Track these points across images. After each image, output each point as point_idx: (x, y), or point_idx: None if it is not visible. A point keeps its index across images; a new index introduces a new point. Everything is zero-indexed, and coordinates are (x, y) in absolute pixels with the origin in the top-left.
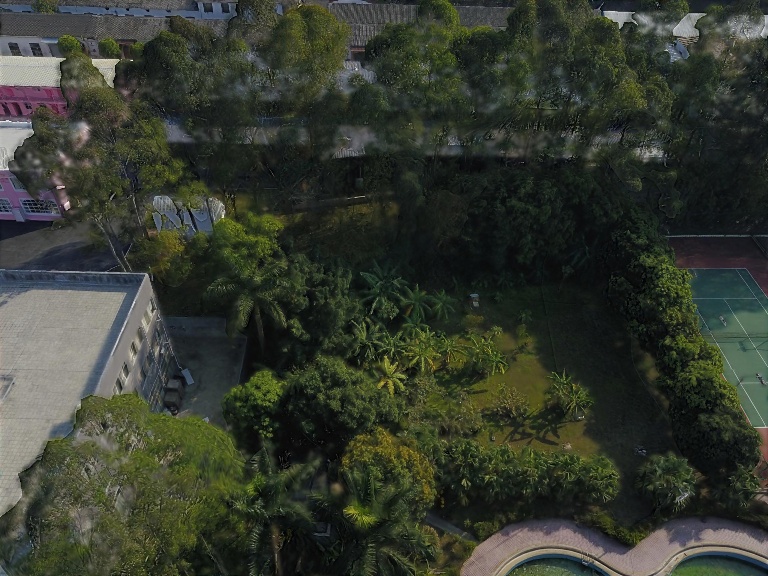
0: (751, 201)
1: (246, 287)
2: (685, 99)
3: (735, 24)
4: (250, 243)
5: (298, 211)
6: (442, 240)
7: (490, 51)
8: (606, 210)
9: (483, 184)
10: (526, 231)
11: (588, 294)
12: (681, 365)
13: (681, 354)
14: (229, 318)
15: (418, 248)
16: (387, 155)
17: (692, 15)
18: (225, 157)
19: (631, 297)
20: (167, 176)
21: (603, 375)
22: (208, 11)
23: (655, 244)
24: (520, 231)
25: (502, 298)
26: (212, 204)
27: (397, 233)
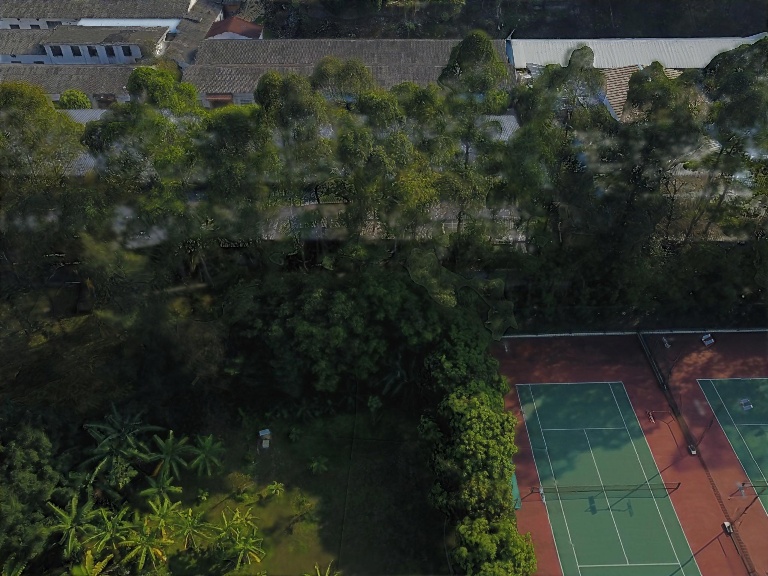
0: (631, 294)
1: None
2: (513, 186)
3: (565, 92)
4: None
5: (83, 313)
6: (201, 374)
7: (229, 141)
8: (416, 329)
9: (245, 305)
10: (317, 356)
11: (412, 425)
12: (472, 567)
13: (474, 551)
14: None
15: (178, 382)
16: (111, 274)
17: (613, 42)
18: None
19: (439, 449)
20: None
21: (399, 556)
22: (57, 55)
23: (475, 375)
24: (309, 356)
25: (299, 435)
26: None
27: (137, 370)
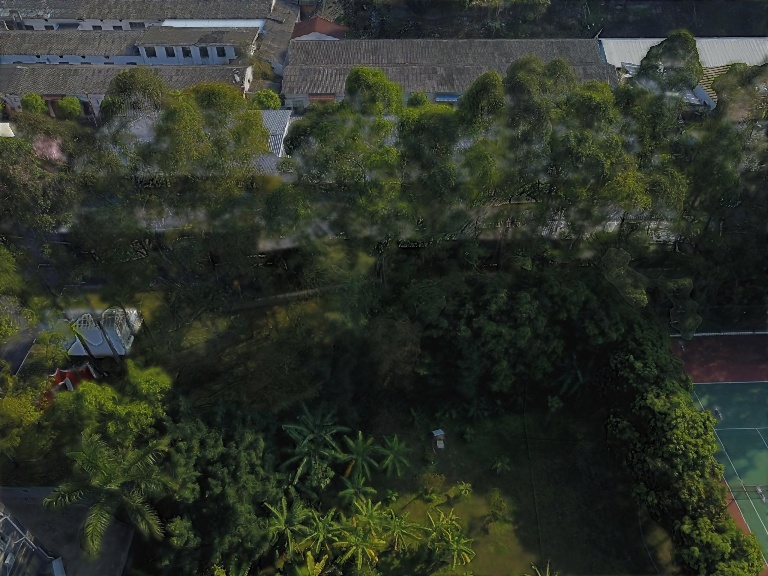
0: None
1: (102, 491)
2: (701, 185)
3: (765, 91)
4: (118, 416)
5: None
6: (390, 375)
7: (441, 141)
8: (602, 329)
9: (440, 305)
10: (500, 356)
11: (583, 425)
12: (706, 567)
13: (705, 551)
14: (83, 530)
15: (362, 382)
16: (312, 275)
17: (704, 41)
18: (108, 279)
19: (636, 449)
20: (3, 332)
21: (602, 556)
22: (151, 56)
23: (666, 375)
24: (492, 356)
25: (473, 435)
26: (115, 318)
27: (331, 370)
